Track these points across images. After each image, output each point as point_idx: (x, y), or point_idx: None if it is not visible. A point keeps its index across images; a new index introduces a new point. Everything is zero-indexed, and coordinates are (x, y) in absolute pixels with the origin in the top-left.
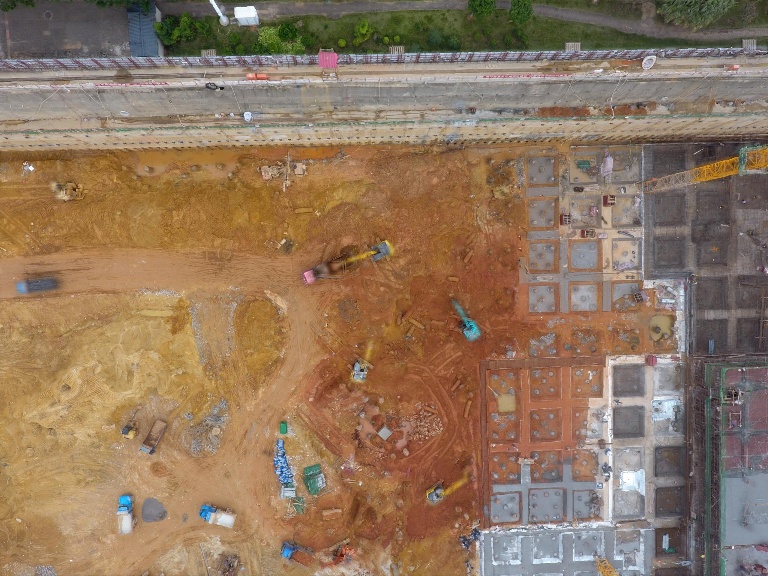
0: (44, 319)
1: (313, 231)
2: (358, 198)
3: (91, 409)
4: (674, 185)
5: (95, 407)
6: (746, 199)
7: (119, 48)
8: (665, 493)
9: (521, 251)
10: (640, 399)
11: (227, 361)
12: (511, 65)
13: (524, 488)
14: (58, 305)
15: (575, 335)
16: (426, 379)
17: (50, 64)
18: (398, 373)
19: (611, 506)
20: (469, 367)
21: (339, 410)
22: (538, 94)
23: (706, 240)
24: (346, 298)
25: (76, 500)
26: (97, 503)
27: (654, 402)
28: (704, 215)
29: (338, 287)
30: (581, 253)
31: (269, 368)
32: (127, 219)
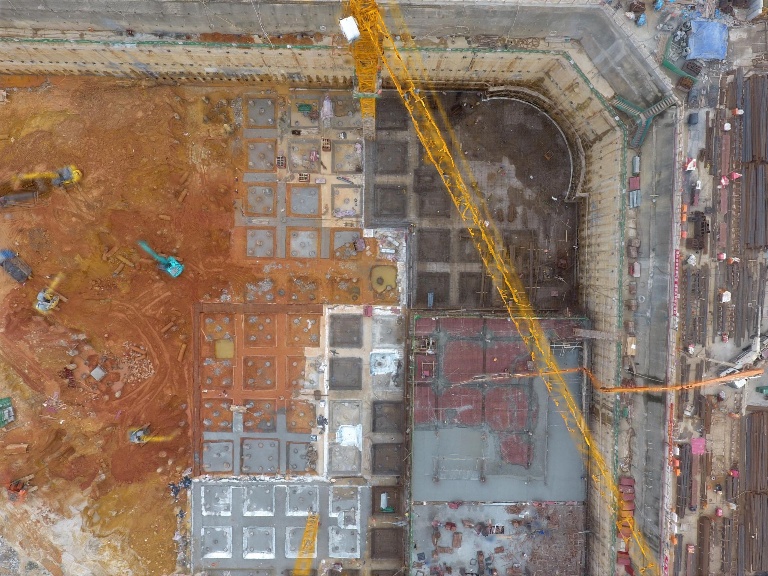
0: None
1: (6, 157)
2: (55, 127)
3: None
4: None
5: None
6: (468, 150)
7: None
8: (384, 450)
9: (237, 193)
10: (358, 351)
11: None
12: None
13: (236, 437)
14: None
15: (294, 282)
16: (131, 317)
17: None
18: (104, 310)
19: (326, 460)
20: (183, 309)
21: (40, 345)
22: (179, 14)
23: (428, 190)
24: (36, 227)
25: None
26: None
27: (377, 355)
28: (429, 165)
29: (29, 216)
30: (301, 198)
31: None
32: None
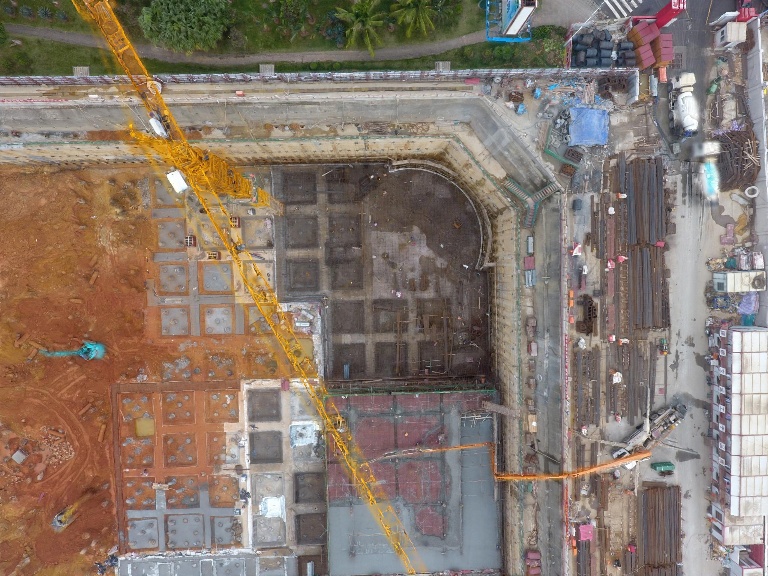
0: None
1: None
2: None
3: None
4: (262, 209)
5: None
6: (378, 222)
7: None
8: (309, 520)
9: (149, 273)
10: (277, 424)
11: None
12: (14, 89)
13: (160, 514)
14: None
15: (211, 358)
16: (46, 403)
17: None
18: (20, 396)
19: (251, 533)
20: (101, 390)
21: None
22: (58, 118)
23: (339, 263)
24: None
25: None
26: None
27: (297, 427)
28: (340, 237)
29: None
30: (214, 275)
31: None
32: None
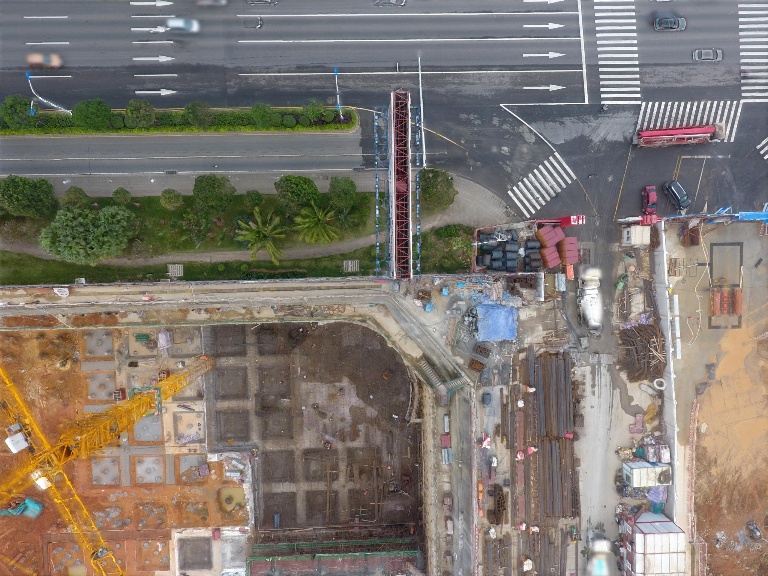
0: None
1: None
2: None
3: None
4: None
5: None
6: (307, 374)
7: None
8: None
9: None
10: (208, 572)
11: None
12: None
13: None
14: None
15: (142, 507)
16: None
17: None
18: None
19: None
20: (32, 539)
21: None
22: None
23: None
24: None
25: None
26: None
27: (229, 572)
28: (271, 387)
29: None
30: (144, 425)
31: None
32: None
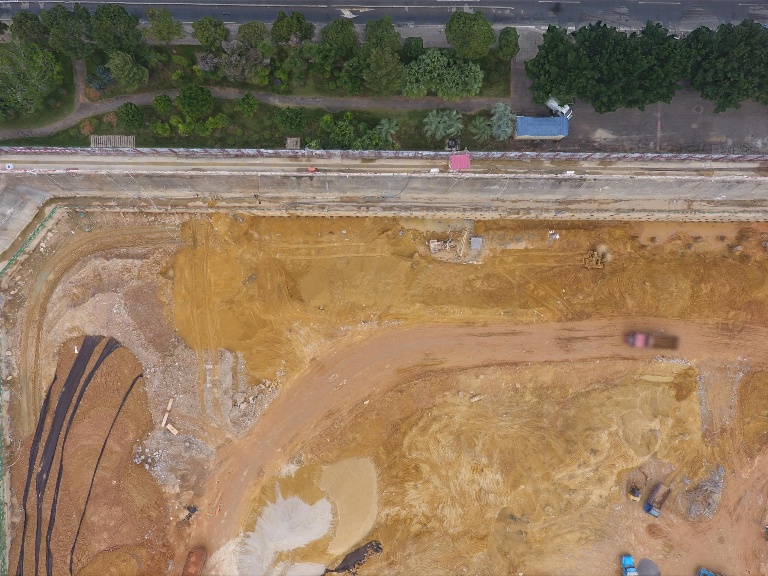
0: (558, 381)
1: None
2: None
3: (611, 472)
4: None
5: (615, 470)
6: None
7: (761, 142)
8: None
9: None
10: None
11: (726, 429)
12: None
13: None
14: (583, 369)
15: None
16: None
17: (709, 157)
18: None
19: None
20: None
21: None
22: None
23: None
24: None
25: (574, 557)
26: (594, 561)
27: None
28: None
29: None
30: None
31: (765, 437)
32: (657, 290)
